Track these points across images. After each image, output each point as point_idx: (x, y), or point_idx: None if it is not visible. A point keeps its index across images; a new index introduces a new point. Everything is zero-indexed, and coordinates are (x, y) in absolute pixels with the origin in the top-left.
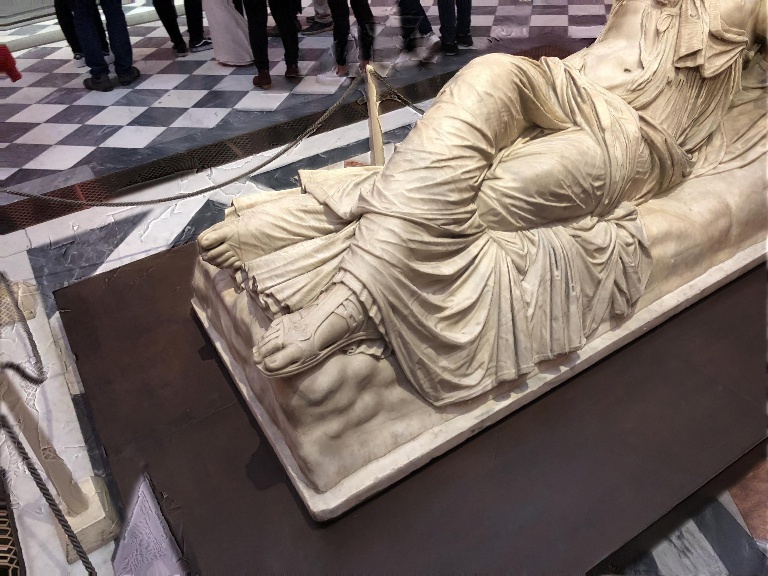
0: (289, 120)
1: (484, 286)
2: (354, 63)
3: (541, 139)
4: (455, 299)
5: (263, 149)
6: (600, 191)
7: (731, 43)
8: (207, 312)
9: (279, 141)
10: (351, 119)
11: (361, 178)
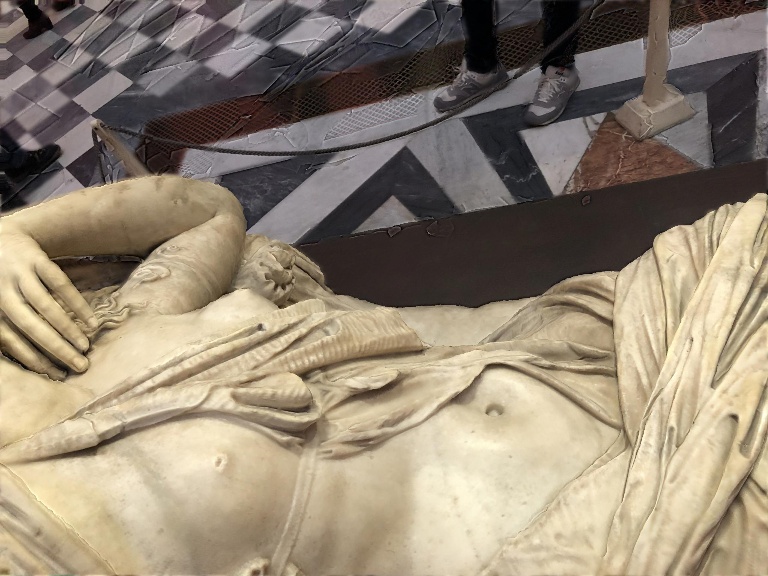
0: None
1: None
2: None
3: None
4: None
5: None
6: None
7: None
8: None
9: None
10: None
11: None
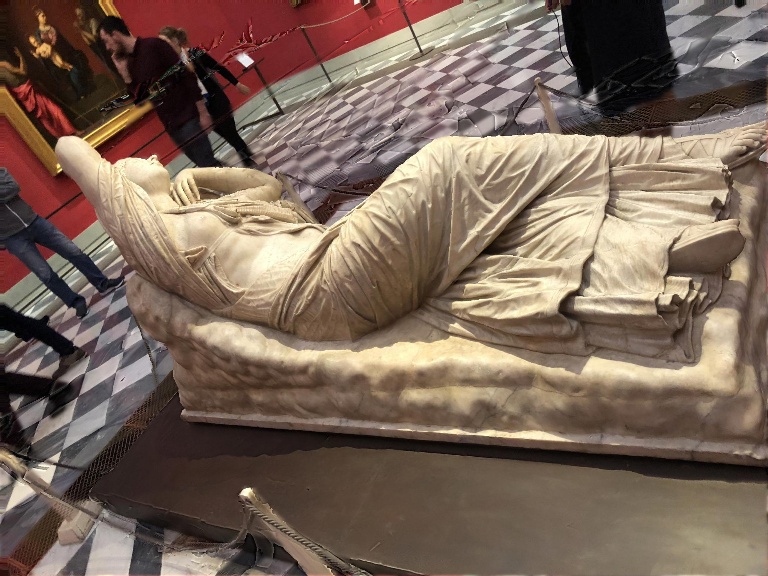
0: None
1: None
2: None
3: None
4: None
5: None
6: None
7: None
8: (765, 385)
9: None
10: None
11: (561, 205)
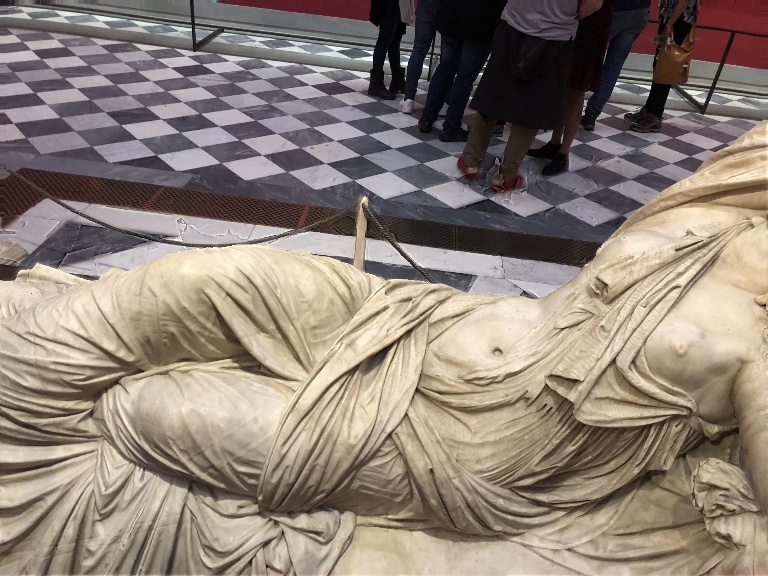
0: (384, 214)
1: (36, 498)
2: (499, 188)
3: (245, 375)
4: (3, 491)
5: (324, 230)
6: (257, 480)
7: (650, 397)
8: None
9: (350, 229)
10: (434, 241)
11: None
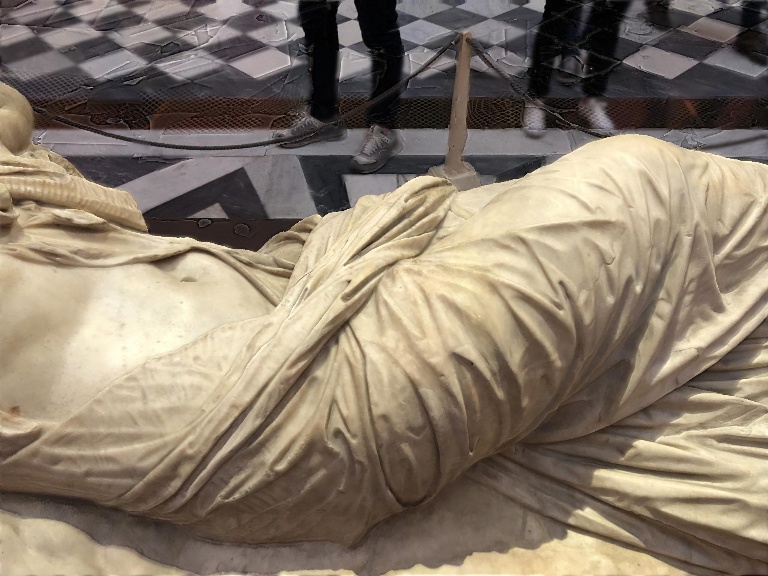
0: None
1: None
2: None
3: None
4: None
5: None
6: None
7: None
8: None
9: None
10: None
11: None
